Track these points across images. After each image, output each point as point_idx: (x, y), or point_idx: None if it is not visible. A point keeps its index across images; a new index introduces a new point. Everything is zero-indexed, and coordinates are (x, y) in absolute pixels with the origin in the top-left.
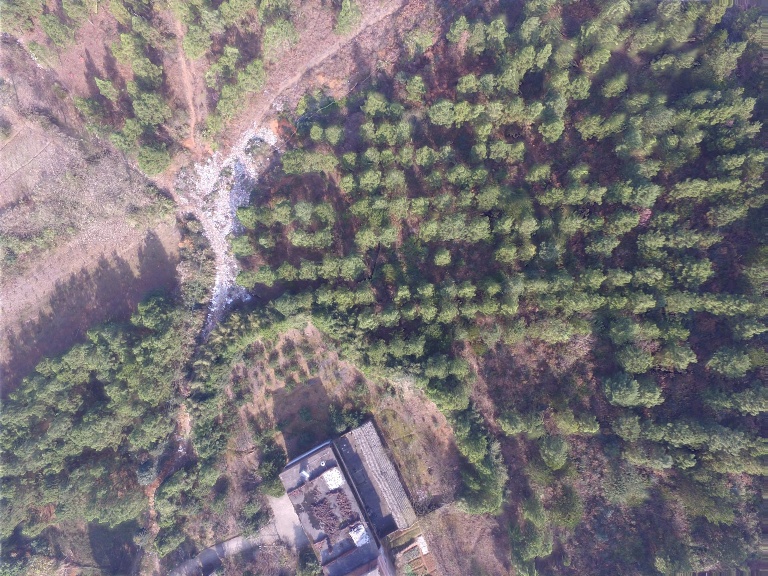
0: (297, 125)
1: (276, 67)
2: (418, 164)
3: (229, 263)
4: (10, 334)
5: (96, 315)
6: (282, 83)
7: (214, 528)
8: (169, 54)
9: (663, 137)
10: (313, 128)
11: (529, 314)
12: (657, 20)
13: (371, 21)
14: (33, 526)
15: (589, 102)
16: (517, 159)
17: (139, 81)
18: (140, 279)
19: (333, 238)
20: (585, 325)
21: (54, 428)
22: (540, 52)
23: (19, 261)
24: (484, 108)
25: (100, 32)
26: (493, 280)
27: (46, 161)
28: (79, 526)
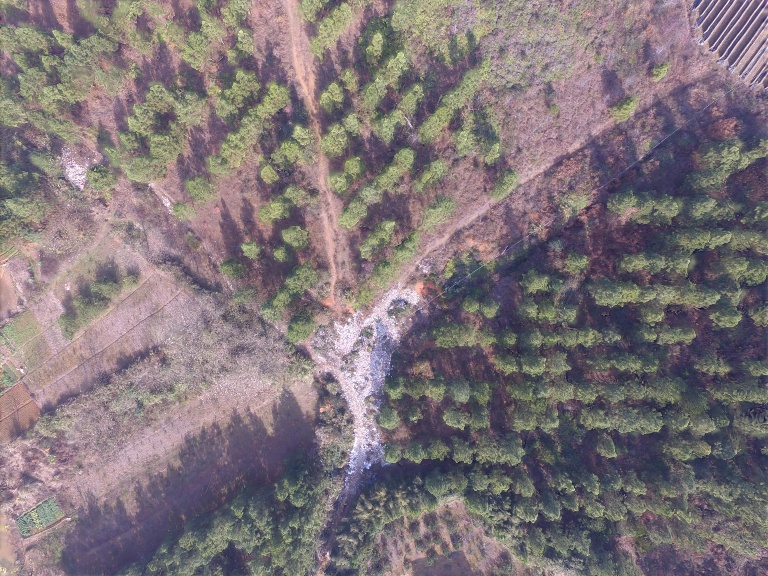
0: (445, 289)
1: (424, 228)
2: (578, 343)
3: (368, 426)
4: (137, 486)
5: (227, 471)
6: (429, 244)
7: None
8: (311, 210)
9: None
10: (472, 306)
11: (695, 508)
12: None
13: (522, 180)
14: None
15: (762, 286)
16: (682, 341)
17: (286, 245)
18: (274, 437)
19: None
20: (764, 534)
21: None
22: (716, 237)
23: (147, 412)
24: (656, 294)
25: (238, 182)
26: (660, 474)
27: (177, 310)
28: None
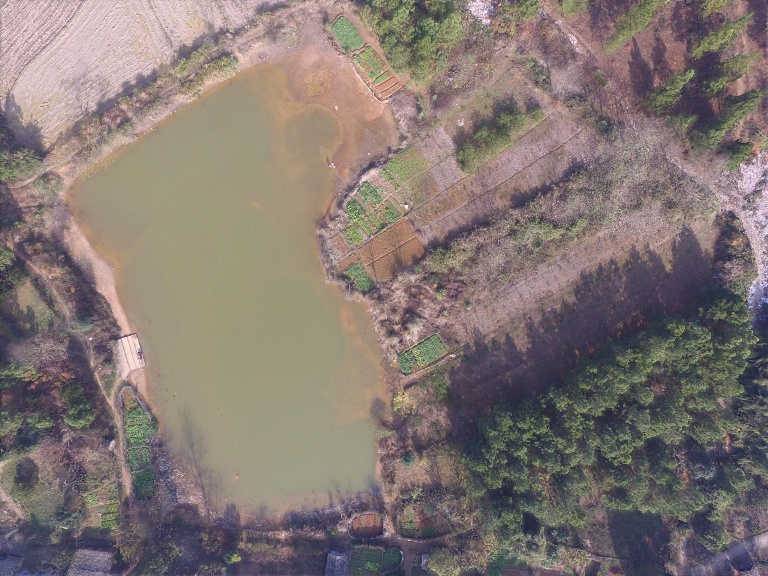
0: None
1: None
2: None
3: (767, 263)
4: (529, 321)
5: (624, 307)
6: None
7: (748, 522)
8: (727, 51)
9: None
10: None
11: None
12: None
13: None
14: (585, 516)
15: None
16: None
17: None
18: (672, 273)
19: None
20: None
21: (648, 420)
22: None
23: (543, 248)
24: None
25: (652, 22)
26: None
27: (577, 148)
28: (596, 517)
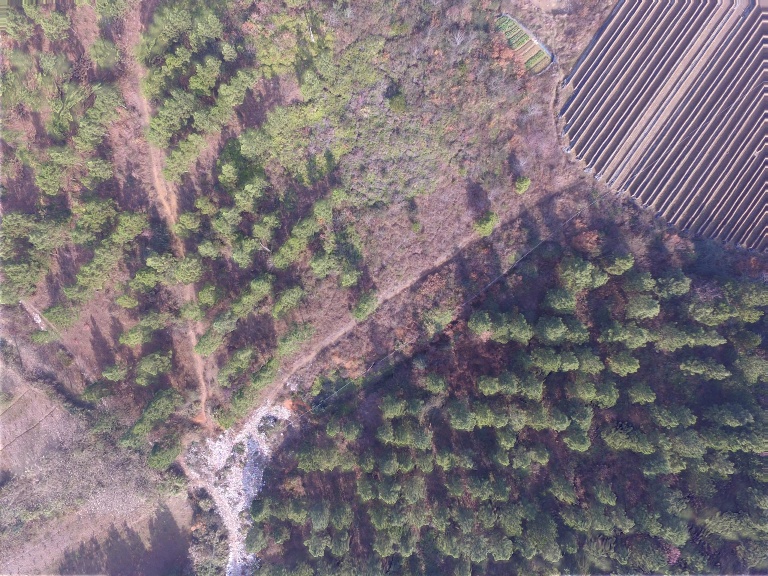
0: (312, 407)
1: None
2: None
3: (242, 541)
4: None
5: None
6: (296, 362)
7: None
8: (178, 329)
9: (693, 464)
10: (330, 433)
11: None
12: (688, 324)
13: (388, 295)
14: None
15: (616, 408)
16: None
17: None
18: (151, 551)
19: (350, 537)
20: None
21: None
22: (566, 363)
23: (26, 527)
24: (507, 421)
25: (106, 301)
26: None
27: (52, 426)
28: None
